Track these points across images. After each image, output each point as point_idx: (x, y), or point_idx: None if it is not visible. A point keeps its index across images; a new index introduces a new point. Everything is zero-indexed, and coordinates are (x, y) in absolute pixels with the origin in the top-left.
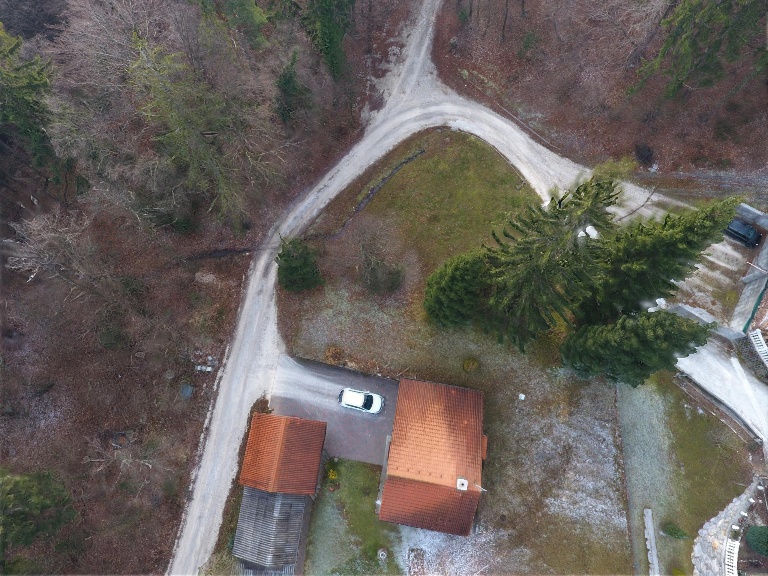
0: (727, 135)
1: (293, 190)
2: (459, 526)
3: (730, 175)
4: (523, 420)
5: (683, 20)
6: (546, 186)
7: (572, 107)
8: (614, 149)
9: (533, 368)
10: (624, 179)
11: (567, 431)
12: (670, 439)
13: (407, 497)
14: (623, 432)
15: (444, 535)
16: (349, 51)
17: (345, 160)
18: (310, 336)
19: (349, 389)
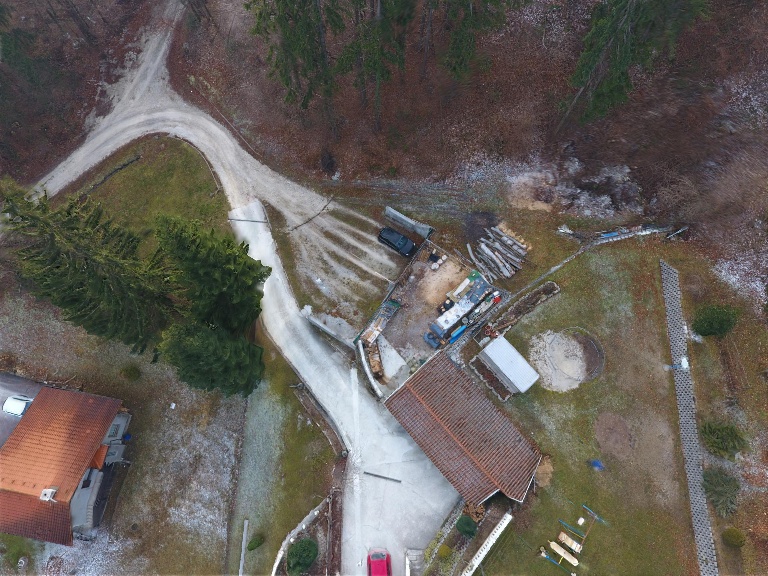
0: (397, 144)
1: (2, 196)
2: (60, 536)
3: (401, 184)
4: (169, 429)
5: (259, 30)
6: (239, 194)
7: (277, 114)
8: (305, 157)
9: None
10: (309, 187)
11: (201, 441)
12: (281, 450)
13: (4, 506)
14: (245, 442)
15: (82, 543)
16: (86, 56)
17: (61, 166)
18: None
19: (15, 397)
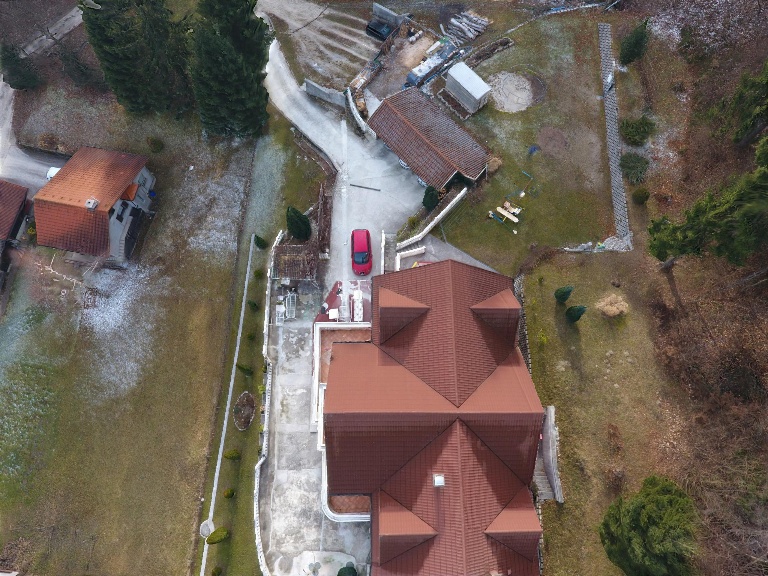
0: None
1: (43, 19)
2: (99, 247)
3: None
4: (188, 185)
5: None
6: None
7: None
8: None
9: (201, 143)
10: None
11: (216, 188)
12: (282, 183)
13: (54, 220)
14: (252, 183)
15: (115, 276)
16: None
17: None
18: (31, 127)
19: None
